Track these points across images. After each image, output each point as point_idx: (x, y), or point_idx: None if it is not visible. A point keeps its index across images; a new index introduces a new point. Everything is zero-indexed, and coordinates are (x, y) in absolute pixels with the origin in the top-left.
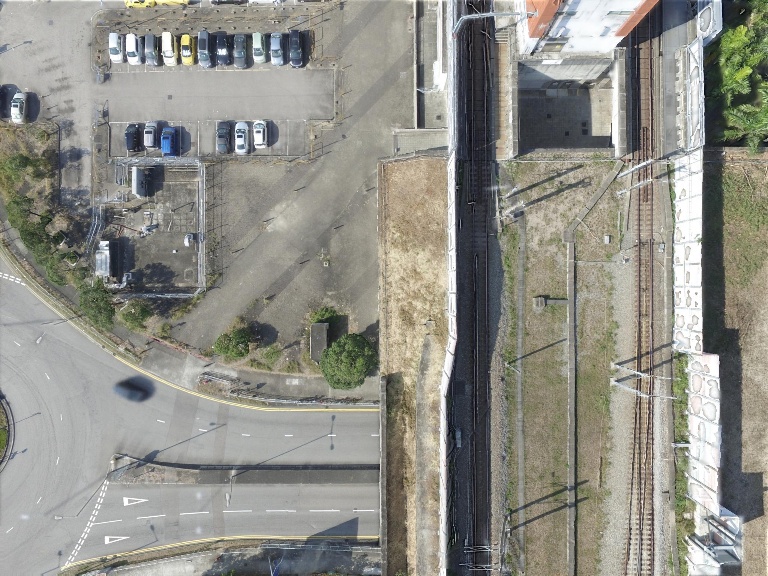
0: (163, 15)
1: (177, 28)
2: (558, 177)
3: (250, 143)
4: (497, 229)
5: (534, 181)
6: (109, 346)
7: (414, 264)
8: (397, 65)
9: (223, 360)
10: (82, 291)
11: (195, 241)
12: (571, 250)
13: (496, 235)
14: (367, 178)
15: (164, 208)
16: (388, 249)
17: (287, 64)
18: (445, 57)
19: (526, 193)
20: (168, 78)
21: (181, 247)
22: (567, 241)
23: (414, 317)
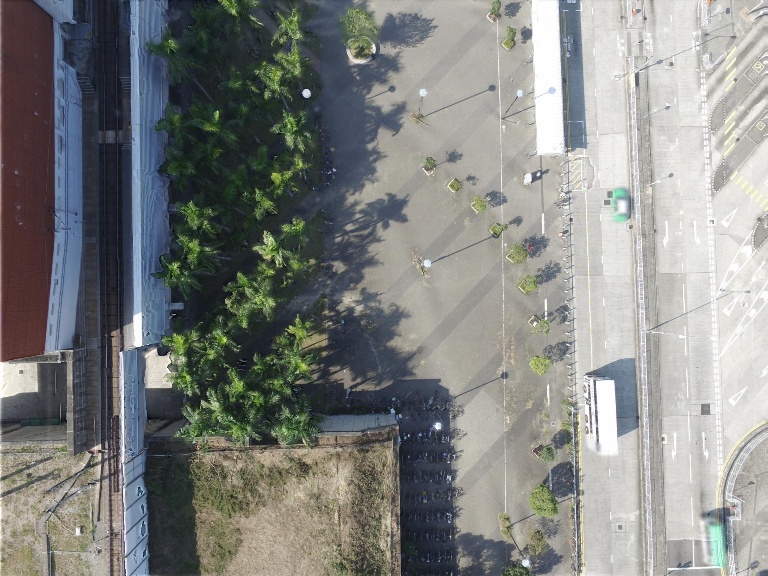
0: None
1: None
2: (27, 469)
3: None
4: None
5: (3, 474)
6: None
7: None
8: None
9: None
10: None
11: None
12: (43, 542)
13: None
14: None
15: None
16: None
17: None
18: None
19: None
20: None
21: None
22: (39, 533)
23: None
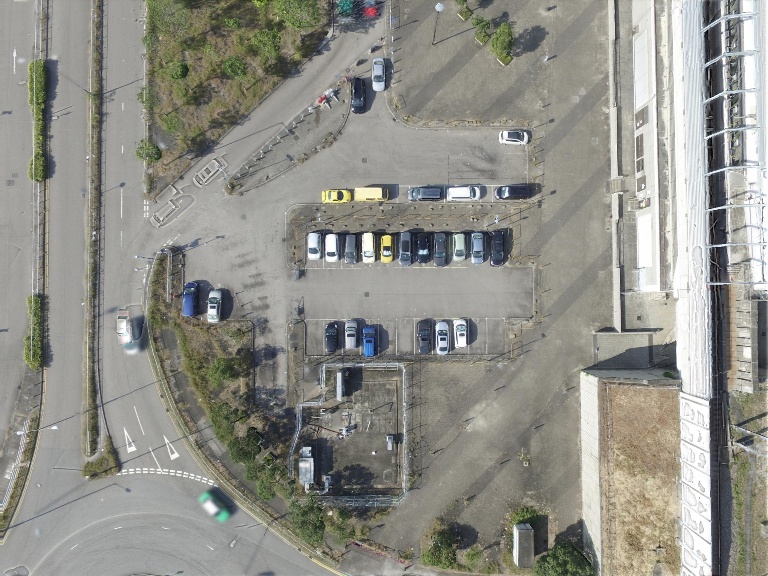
0: (359, 211)
1: (374, 224)
2: None
3: (449, 342)
4: (729, 459)
5: (764, 410)
6: (306, 549)
7: (643, 490)
8: (596, 264)
9: (422, 561)
10: (298, 511)
11: (394, 442)
12: None
13: (728, 464)
14: (567, 377)
15: (363, 408)
16: (612, 470)
17: (485, 261)
18: (663, 275)
19: (756, 422)
20: (365, 275)
21: (380, 448)
22: None
23: (642, 542)
